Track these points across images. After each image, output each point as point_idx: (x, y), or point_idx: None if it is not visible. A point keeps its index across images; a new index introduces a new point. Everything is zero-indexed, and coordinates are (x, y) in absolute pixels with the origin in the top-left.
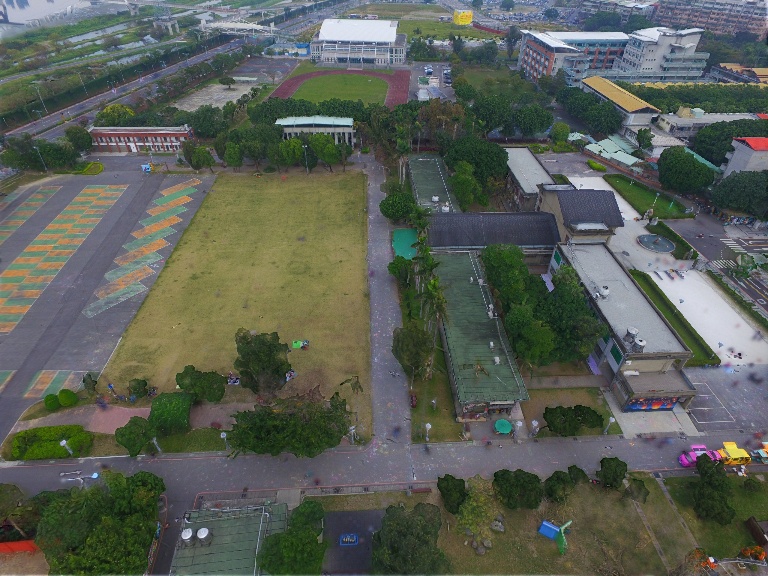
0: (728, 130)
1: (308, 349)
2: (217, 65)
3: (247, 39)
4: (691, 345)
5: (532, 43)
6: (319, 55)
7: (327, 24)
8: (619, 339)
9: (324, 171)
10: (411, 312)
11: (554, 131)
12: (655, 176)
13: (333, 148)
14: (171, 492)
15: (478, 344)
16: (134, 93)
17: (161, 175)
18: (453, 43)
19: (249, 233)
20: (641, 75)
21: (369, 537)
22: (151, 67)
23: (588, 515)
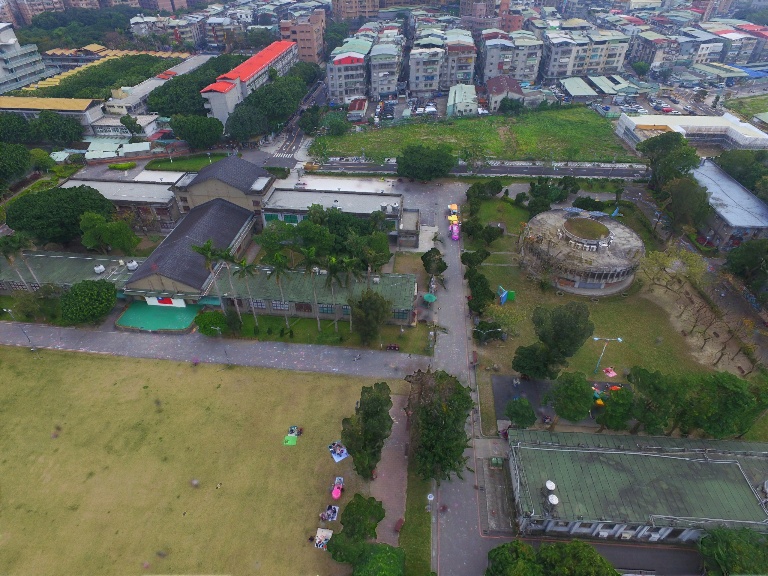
0: (171, 92)
1: (303, 428)
2: None
3: None
4: None
5: None
6: None
7: None
8: (385, 214)
9: None
10: (276, 334)
11: (38, 160)
12: (179, 146)
13: None
14: (481, 568)
15: (353, 288)
16: None
17: None
18: None
19: None
20: None
21: (514, 390)
22: None
23: (489, 283)
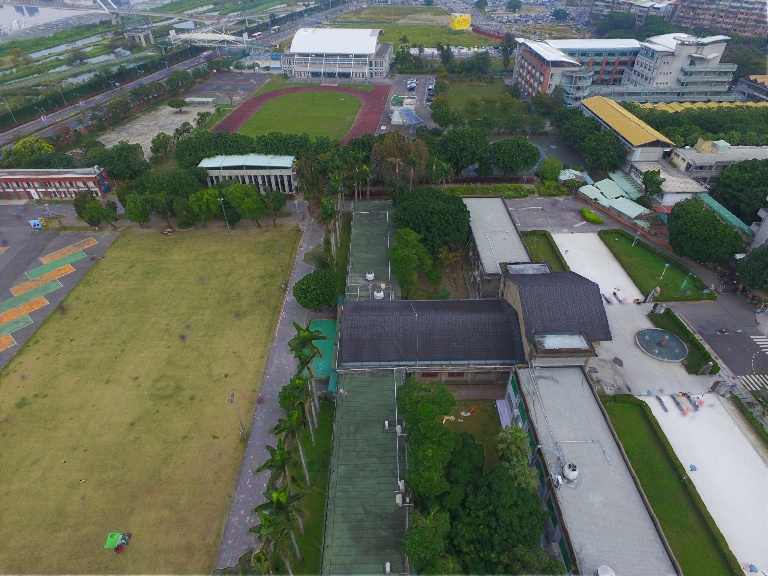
0: (761, 173)
1: (125, 551)
2: (172, 84)
3: (220, 51)
4: (706, 549)
5: (527, 54)
6: (291, 69)
7: (300, 34)
8: None
9: (251, 226)
10: (298, 473)
11: (541, 169)
12: (665, 235)
13: (254, 202)
14: None
15: (369, 563)
16: (70, 119)
17: (52, 233)
18: (441, 53)
19: (123, 326)
20: (654, 91)
21: None
22: (102, 87)
23: None
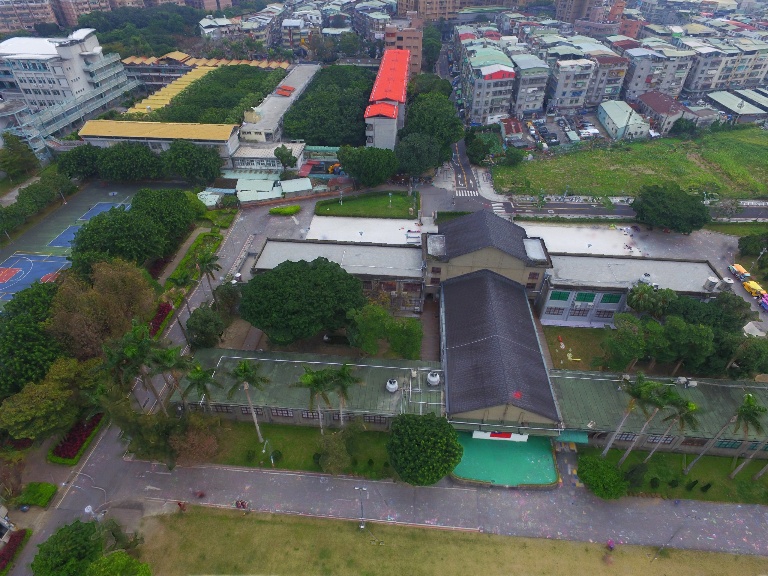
0: None
1: None
2: None
3: None
4: None
5: None
6: None
7: None
8: (718, 293)
9: None
10: None
11: (192, 207)
12: (344, 183)
13: None
14: None
15: None
16: None
17: None
18: None
19: None
20: (84, 101)
21: None
22: None
23: None
